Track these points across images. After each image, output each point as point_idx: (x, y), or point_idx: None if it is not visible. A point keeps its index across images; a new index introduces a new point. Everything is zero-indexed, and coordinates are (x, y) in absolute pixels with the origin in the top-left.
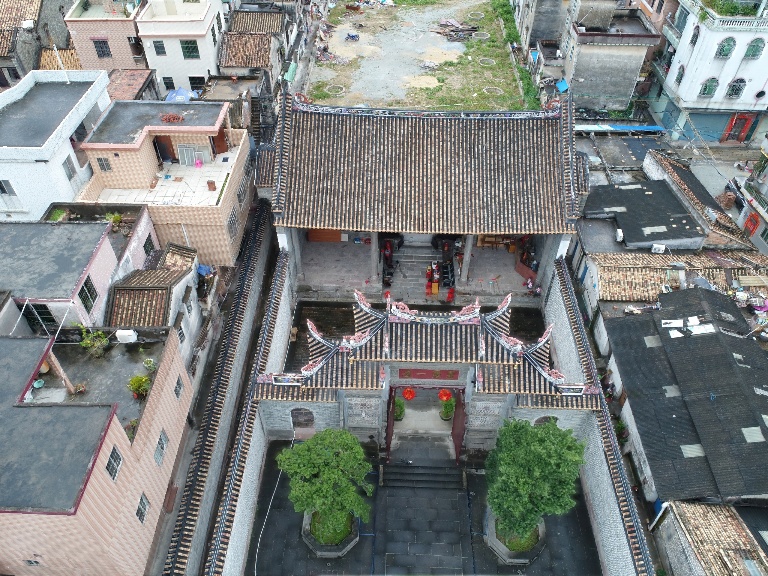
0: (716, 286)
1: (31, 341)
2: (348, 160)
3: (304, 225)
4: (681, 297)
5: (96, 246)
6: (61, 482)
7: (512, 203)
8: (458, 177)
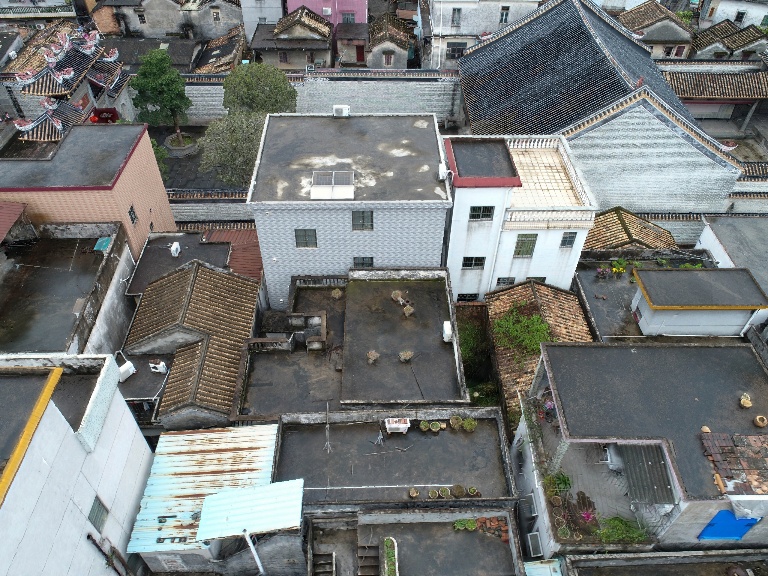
0: None
1: None
2: None
3: None
4: None
5: None
6: (124, 131)
7: None
8: None
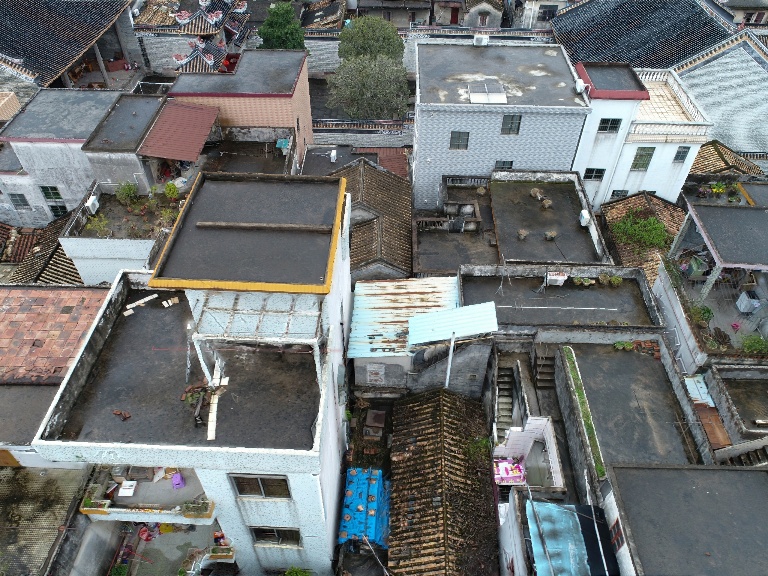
0: (177, 3)
1: (180, 79)
2: (6, 33)
3: (55, 76)
4: (185, 6)
5: (72, 89)
6: (290, 55)
7: (96, 4)
8: (59, 8)
